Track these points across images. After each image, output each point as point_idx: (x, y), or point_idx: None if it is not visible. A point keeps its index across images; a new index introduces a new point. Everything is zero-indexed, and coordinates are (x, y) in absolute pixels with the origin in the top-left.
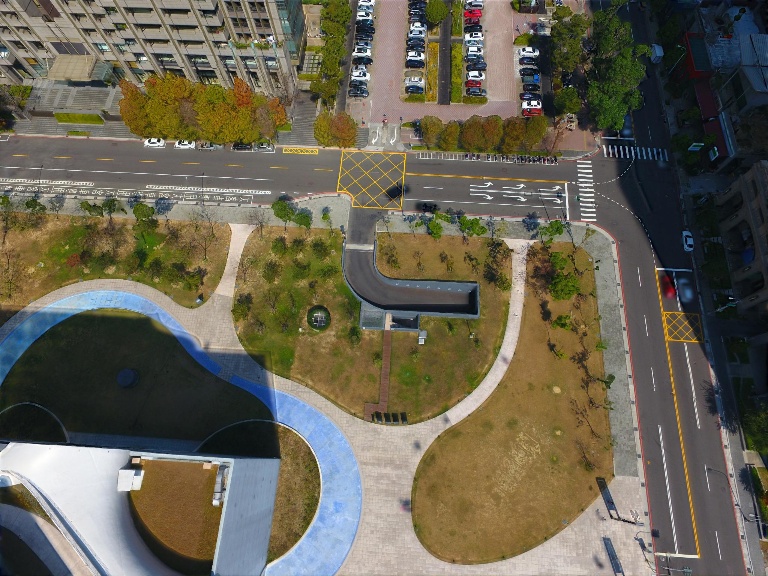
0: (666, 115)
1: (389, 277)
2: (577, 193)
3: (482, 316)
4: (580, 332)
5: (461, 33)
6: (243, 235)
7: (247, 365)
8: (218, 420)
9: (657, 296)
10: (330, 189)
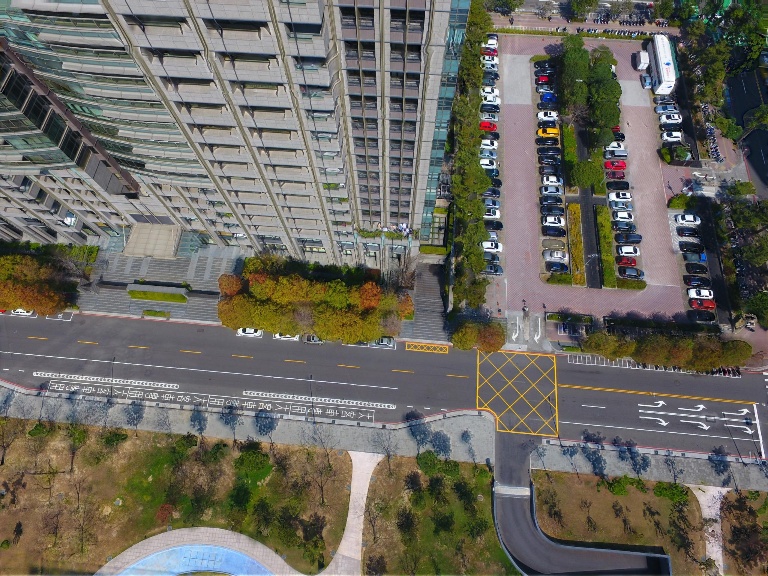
0: None
1: (553, 538)
2: None
3: None
4: None
5: (605, 192)
6: (367, 468)
7: None
8: None
9: None
10: (468, 404)
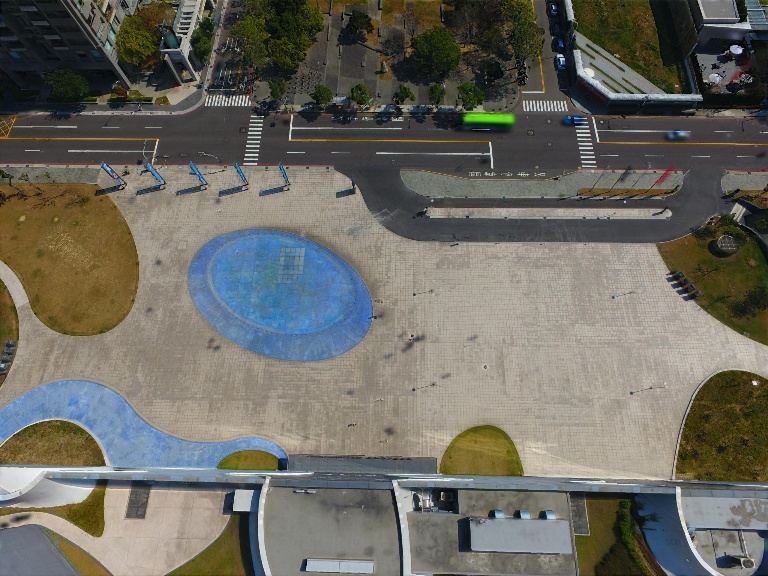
0: None
1: None
2: None
3: None
4: None
5: None
6: None
7: None
8: None
9: None
10: None
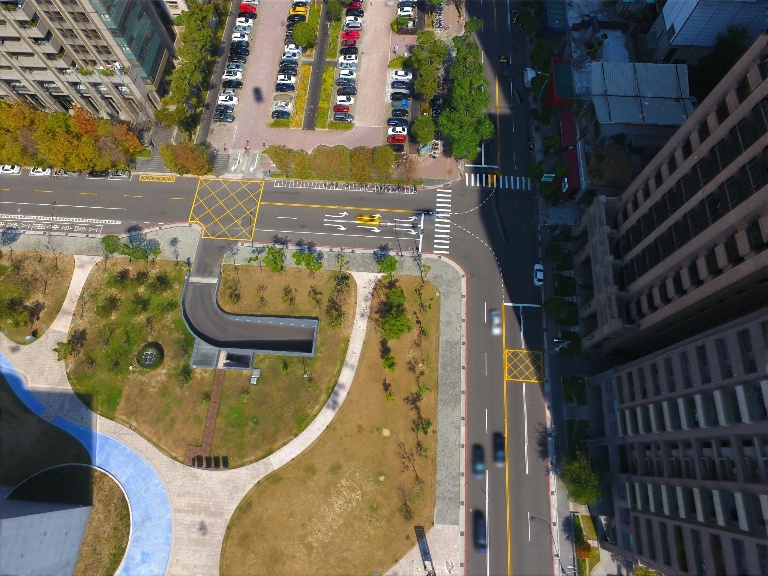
0: (534, 142)
1: (229, 312)
2: (433, 224)
3: (319, 354)
4: (417, 371)
5: (335, 55)
6: (86, 267)
7: (72, 405)
8: (34, 464)
9: (501, 333)
10: (182, 219)
